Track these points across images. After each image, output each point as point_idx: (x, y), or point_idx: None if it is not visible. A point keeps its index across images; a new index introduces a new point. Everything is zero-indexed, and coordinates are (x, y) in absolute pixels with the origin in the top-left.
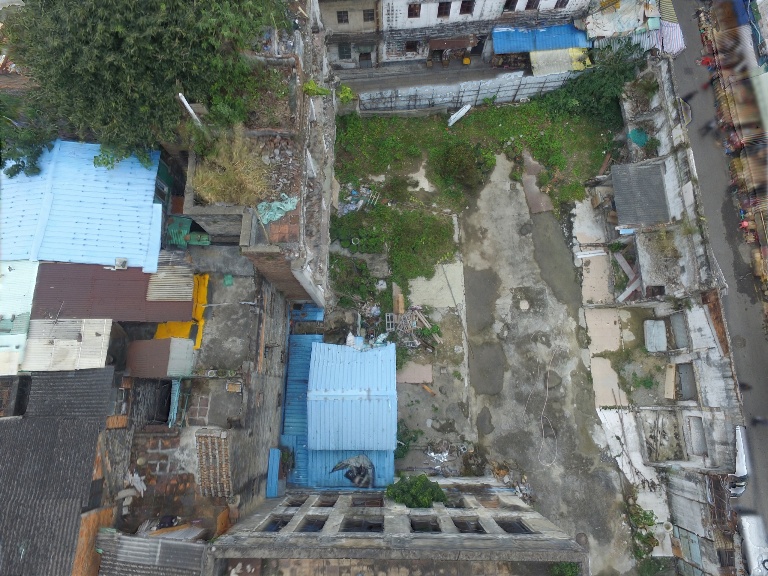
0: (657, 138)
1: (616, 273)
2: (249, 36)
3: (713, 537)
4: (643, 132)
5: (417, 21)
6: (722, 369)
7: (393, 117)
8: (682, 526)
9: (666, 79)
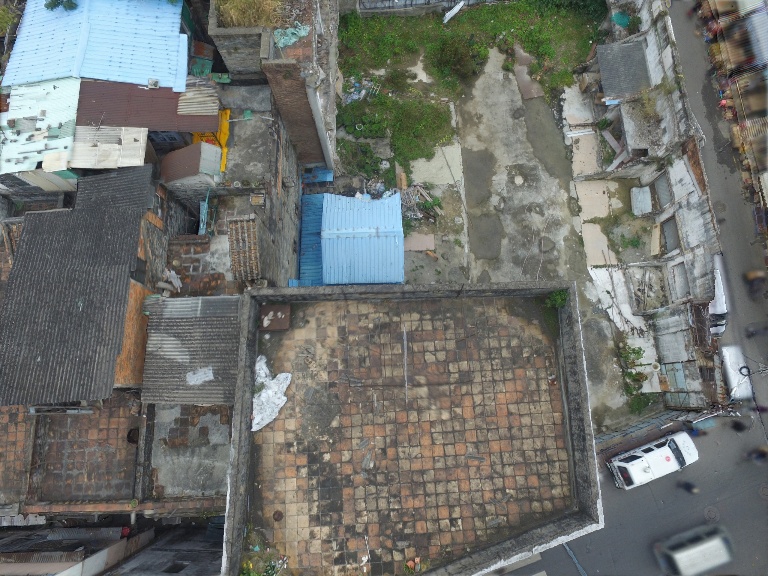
0: None
1: (604, 148)
2: None
3: (695, 357)
4: (626, 14)
5: None
6: (700, 207)
7: (391, 16)
8: (668, 361)
9: None
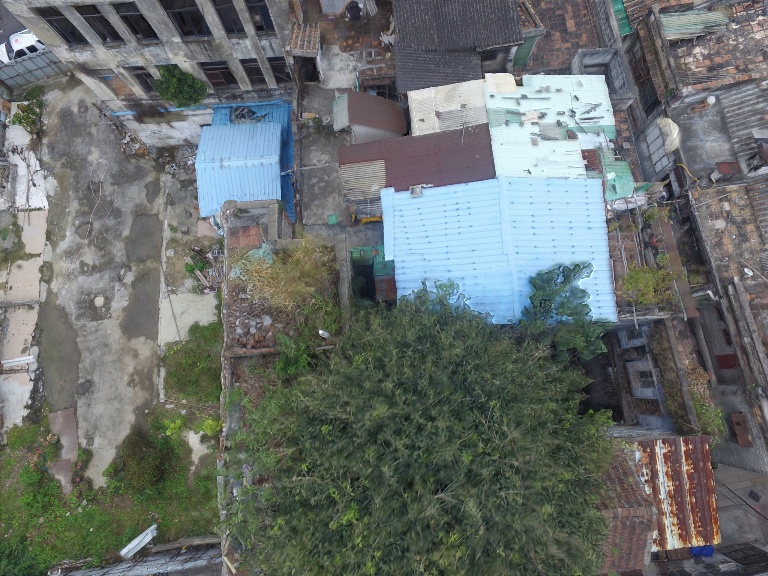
0: None
1: None
2: None
3: None
4: None
5: None
6: None
7: None
8: None
9: None
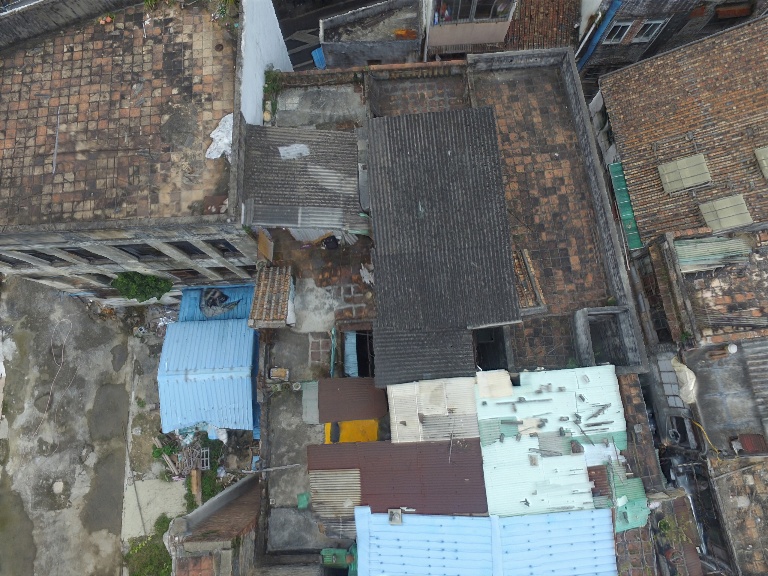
0: None
1: None
2: None
3: None
4: None
5: None
6: None
7: None
8: None
9: None
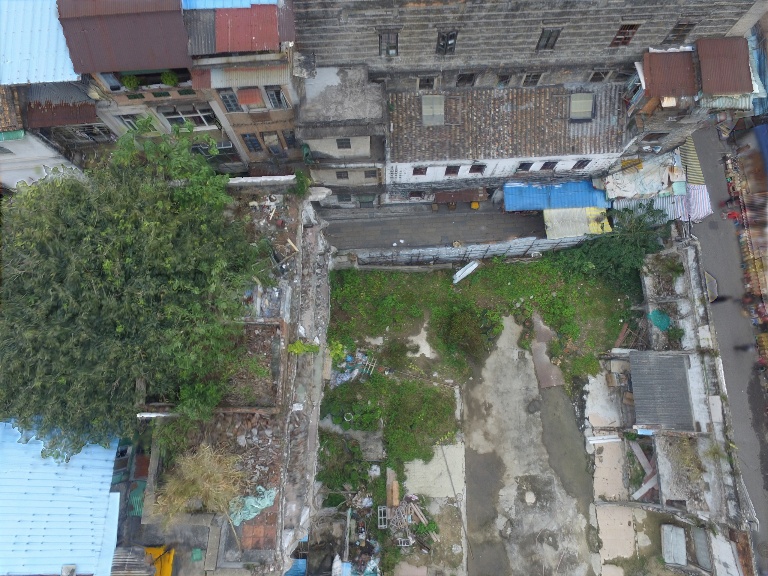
0: (681, 324)
1: (631, 464)
2: (228, 291)
3: None
4: (665, 314)
5: (423, 178)
6: None
7: (394, 272)
8: None
9: (693, 267)
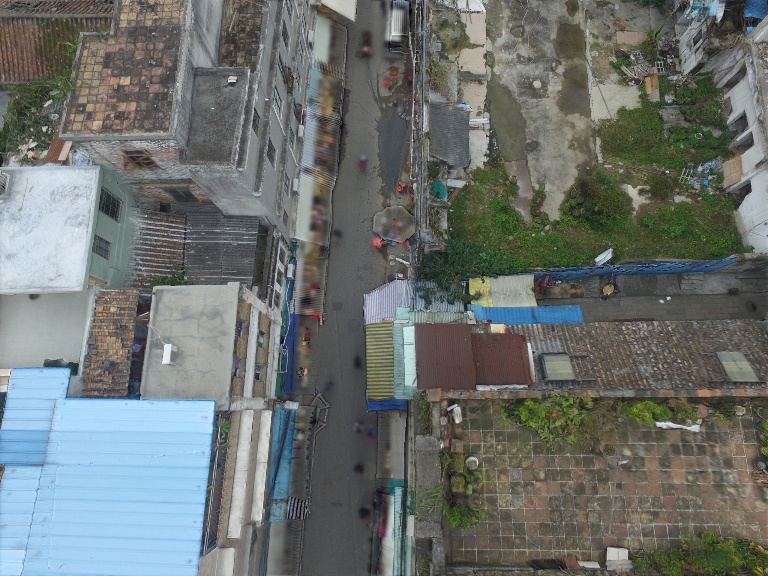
0: None
1: None
2: None
3: None
4: (434, 194)
5: None
6: None
7: None
8: None
9: None
